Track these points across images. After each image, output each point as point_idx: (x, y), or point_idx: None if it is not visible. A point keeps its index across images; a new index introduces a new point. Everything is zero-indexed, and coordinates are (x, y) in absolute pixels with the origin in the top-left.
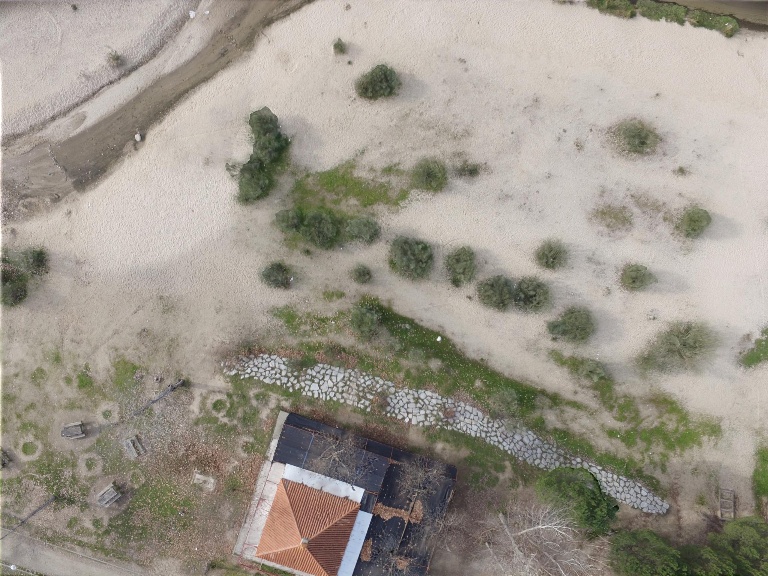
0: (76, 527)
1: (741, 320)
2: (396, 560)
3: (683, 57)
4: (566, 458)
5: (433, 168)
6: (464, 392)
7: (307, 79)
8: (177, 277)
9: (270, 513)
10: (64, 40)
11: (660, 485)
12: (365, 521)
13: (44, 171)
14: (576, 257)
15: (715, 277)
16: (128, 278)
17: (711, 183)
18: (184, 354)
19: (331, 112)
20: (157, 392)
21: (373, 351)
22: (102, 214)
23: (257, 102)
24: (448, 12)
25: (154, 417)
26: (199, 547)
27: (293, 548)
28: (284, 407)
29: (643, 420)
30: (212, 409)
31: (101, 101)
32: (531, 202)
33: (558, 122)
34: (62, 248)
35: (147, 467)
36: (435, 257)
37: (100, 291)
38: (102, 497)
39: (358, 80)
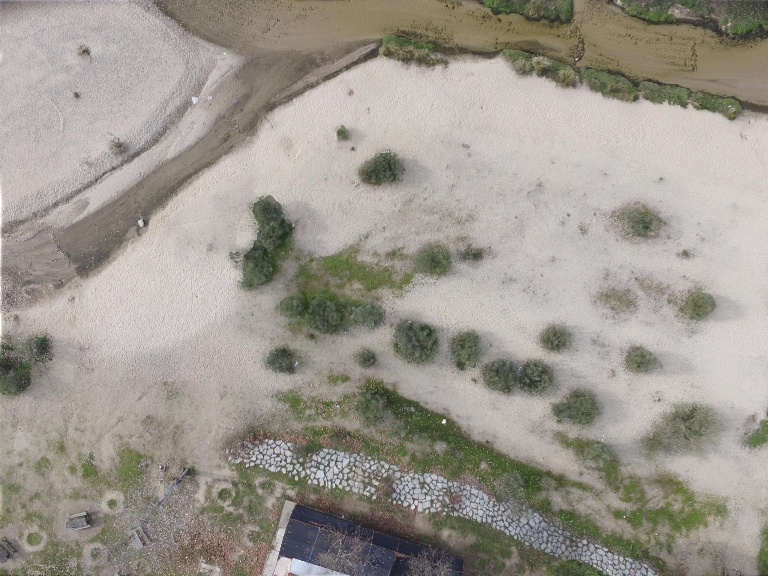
0: None
1: (746, 401)
2: None
3: (686, 140)
4: (572, 541)
5: (437, 252)
6: (470, 474)
7: (310, 165)
8: (181, 362)
9: None
10: (66, 128)
11: (666, 566)
12: None
13: (47, 257)
14: (581, 339)
15: (720, 358)
16: (132, 364)
17: (715, 266)
18: (189, 441)
19: (335, 197)
20: (162, 481)
21: (378, 435)
22: (106, 300)
23: (260, 188)
24: (451, 97)
25: (159, 506)
26: None
27: None
28: (290, 496)
29: (649, 501)
30: (217, 498)
31: (104, 187)
32: (535, 285)
33: (562, 206)
34: (66, 335)
35: (152, 556)
36: (440, 340)
37: (104, 377)
38: None
39: (362, 166)
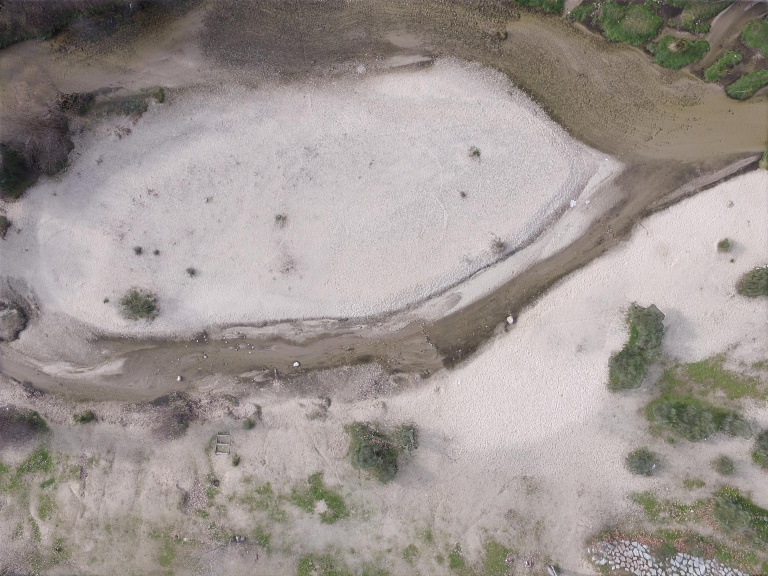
0: None
1: None
2: None
3: None
4: None
5: None
6: None
7: (687, 274)
8: (541, 458)
9: None
10: (450, 225)
11: None
12: None
13: (416, 348)
14: None
15: None
16: (493, 457)
17: None
18: (551, 538)
19: (708, 307)
20: None
21: (730, 542)
22: (472, 393)
23: (634, 293)
24: None
25: None
26: None
27: None
28: None
29: None
30: None
31: (477, 283)
32: None
33: None
34: (431, 425)
35: None
36: None
37: (466, 468)
38: None
39: (739, 278)
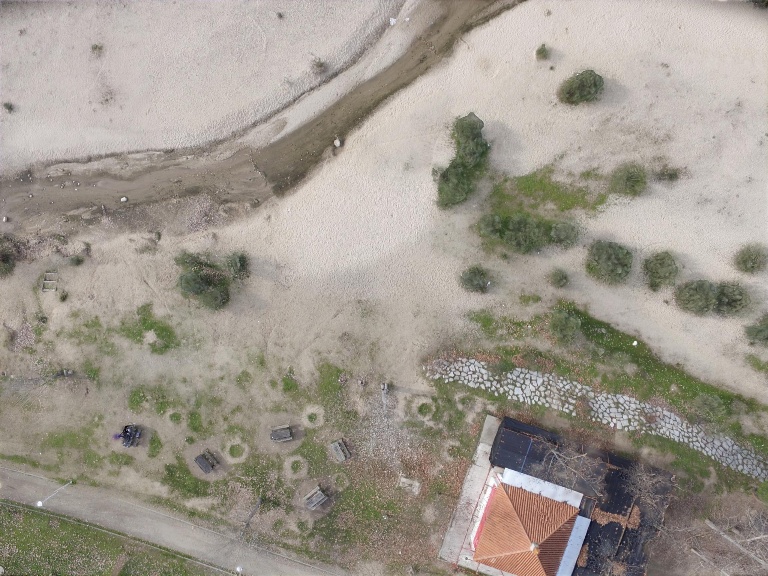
0: (281, 529)
1: None
2: (613, 566)
3: None
4: (766, 464)
5: (633, 172)
6: (660, 397)
7: (508, 85)
8: (375, 281)
9: (489, 517)
10: (269, 48)
11: None
12: (583, 526)
13: (244, 176)
14: None
15: None
16: (327, 282)
17: None
18: (386, 358)
19: (531, 117)
20: (361, 395)
21: (569, 355)
22: (302, 219)
23: (457, 108)
24: (649, 17)
25: (359, 420)
26: (403, 551)
27: (521, 553)
28: (490, 411)
29: None
30: (418, 413)
31: (301, 107)
32: (731, 206)
33: (760, 126)
34: (263, 252)
35: (351, 470)
36: (632, 261)
37: (299, 295)
38: (310, 500)
39: (560, 85)
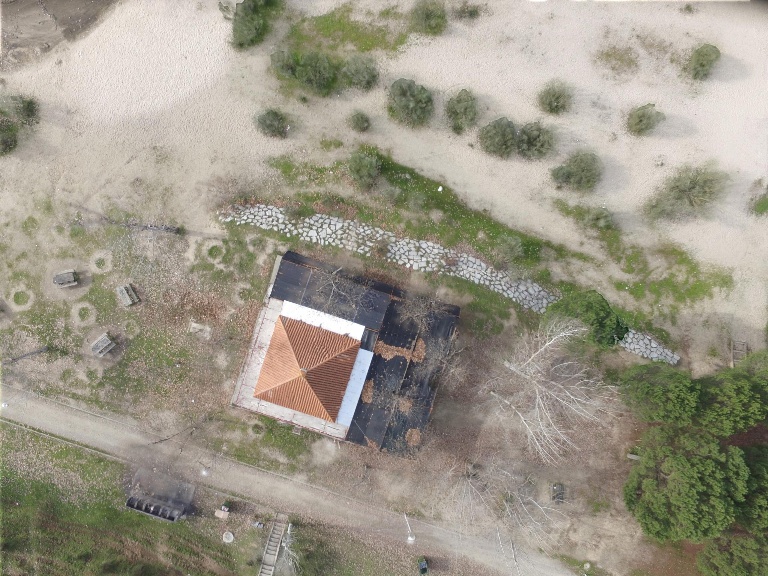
0: (70, 379)
1: (752, 165)
2: (398, 401)
3: None
4: None
5: (432, 10)
6: (467, 244)
7: None
8: (171, 127)
9: (268, 351)
10: None
11: (670, 337)
12: (366, 360)
13: (33, 20)
14: (581, 102)
15: (725, 121)
16: (120, 128)
17: (720, 21)
18: (178, 203)
19: None
20: (151, 240)
21: (373, 202)
22: (93, 63)
23: None
24: None
25: (148, 265)
26: (196, 399)
27: (292, 380)
28: (281, 252)
29: (652, 271)
30: (208, 256)
31: None
32: (534, 44)
33: None
34: (53, 98)
35: (142, 317)
36: (435, 104)
37: (92, 142)
38: (96, 345)
39: None
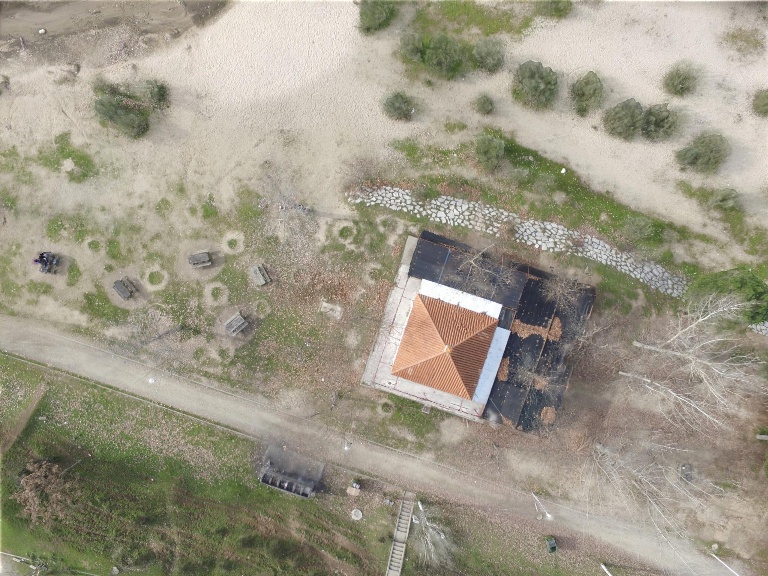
0: (202, 358)
1: None
2: (534, 379)
3: None
4: None
5: None
6: (589, 225)
7: None
8: (297, 111)
9: (406, 329)
10: None
11: None
12: (503, 338)
13: (164, 6)
14: (705, 83)
15: None
16: (248, 112)
17: None
18: (307, 185)
19: None
20: (282, 221)
21: (496, 184)
22: (222, 48)
23: None
24: None
25: (279, 246)
26: (326, 378)
27: (435, 357)
28: (412, 232)
29: None
30: (338, 236)
31: None
32: (659, 27)
33: None
34: (183, 82)
35: (273, 297)
36: (559, 86)
37: (221, 125)
38: (230, 324)
39: None
